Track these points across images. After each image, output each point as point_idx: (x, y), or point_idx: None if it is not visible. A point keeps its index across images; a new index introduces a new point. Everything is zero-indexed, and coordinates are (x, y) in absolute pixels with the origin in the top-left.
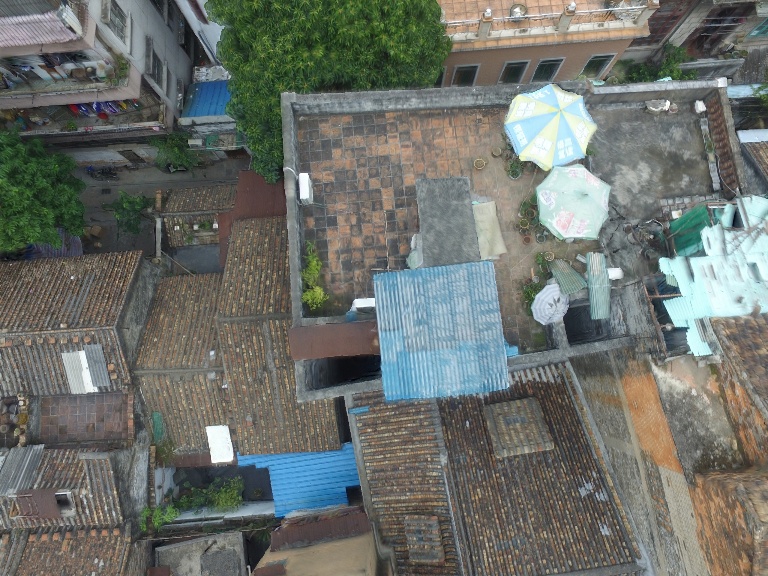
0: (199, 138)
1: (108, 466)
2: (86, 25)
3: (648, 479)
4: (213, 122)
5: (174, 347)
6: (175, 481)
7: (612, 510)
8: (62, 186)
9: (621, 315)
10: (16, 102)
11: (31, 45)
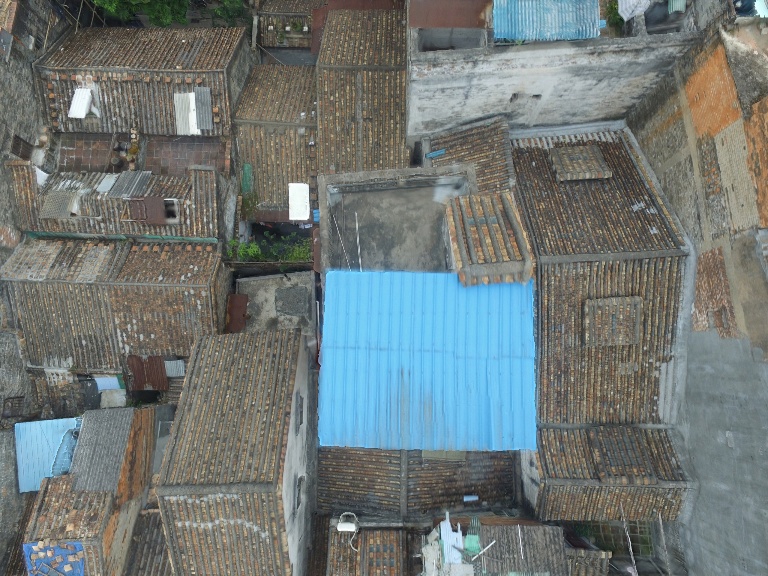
0: None
1: (212, 180)
2: None
3: (701, 162)
4: None
5: (268, 108)
6: None
7: (661, 219)
8: None
9: (693, 21)
10: None
11: None
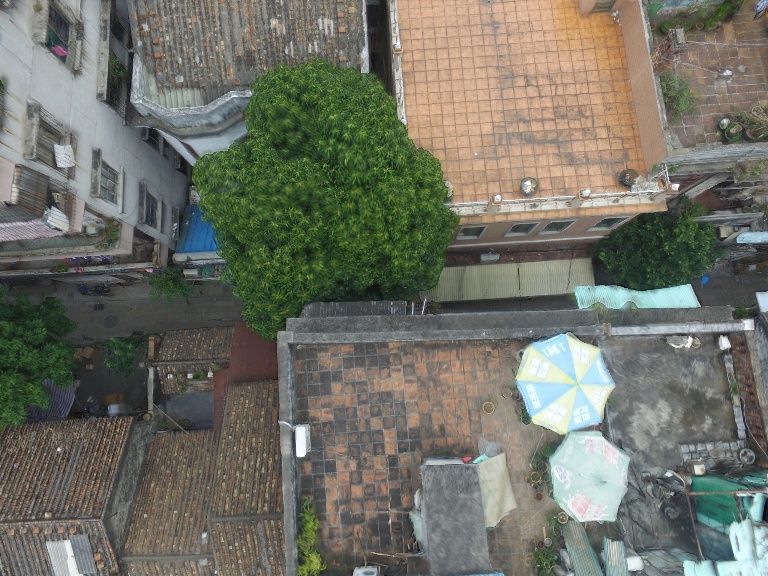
0: (195, 267)
1: None
2: (73, 217)
3: None
4: (209, 258)
5: (165, 526)
6: None
7: None
8: (50, 346)
9: None
10: (2, 259)
11: None
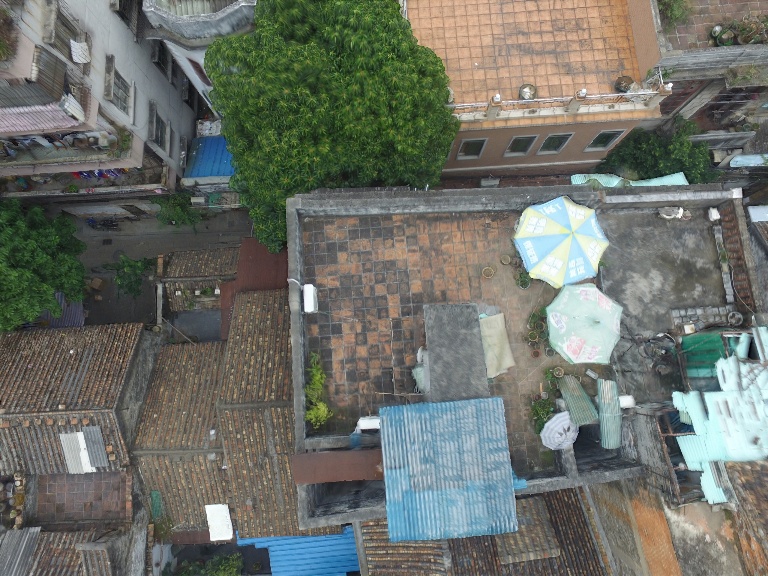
0: (202, 195)
1: (105, 556)
2: (89, 110)
3: None
4: (216, 183)
5: (174, 425)
6: (173, 553)
7: None
8: (62, 256)
9: (632, 440)
10: (17, 171)
11: (32, 130)
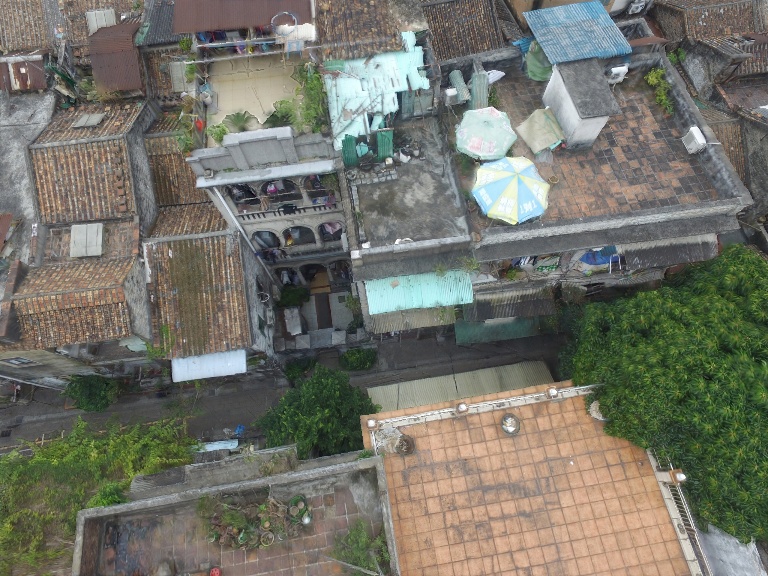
0: None
1: None
2: None
3: None
4: None
5: None
6: None
7: None
8: None
9: None
10: None
11: None
